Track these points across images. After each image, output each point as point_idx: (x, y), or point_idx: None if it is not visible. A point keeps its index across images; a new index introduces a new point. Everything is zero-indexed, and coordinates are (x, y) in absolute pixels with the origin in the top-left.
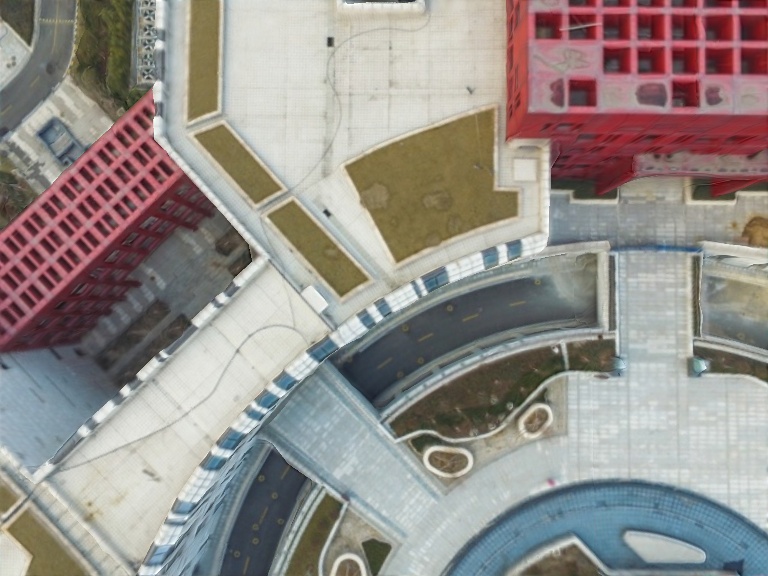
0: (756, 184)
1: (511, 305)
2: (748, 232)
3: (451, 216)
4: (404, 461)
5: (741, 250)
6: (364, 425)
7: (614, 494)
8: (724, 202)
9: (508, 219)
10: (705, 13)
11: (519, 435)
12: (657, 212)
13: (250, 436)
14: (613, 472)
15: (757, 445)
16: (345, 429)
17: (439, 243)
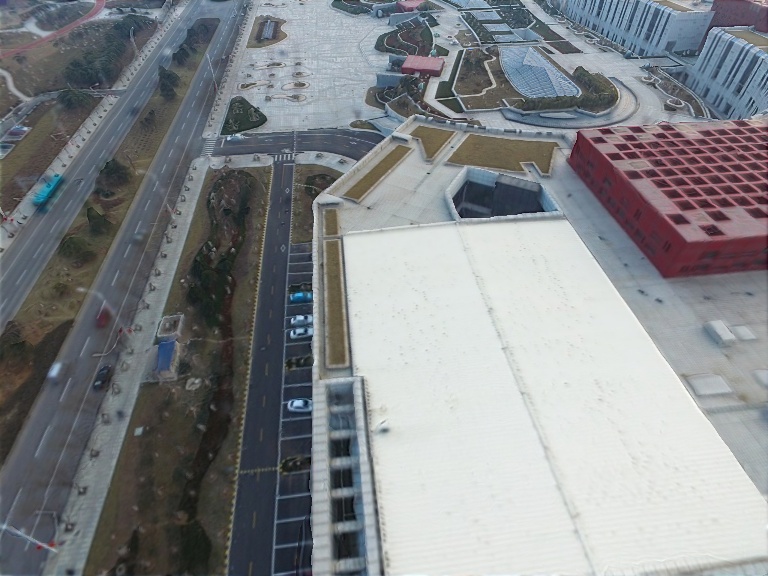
0: None
1: None
2: None
3: None
4: None
5: None
6: None
7: (586, 125)
8: None
9: None
10: (759, 143)
11: None
12: None
13: None
14: None
15: None
16: None
17: None
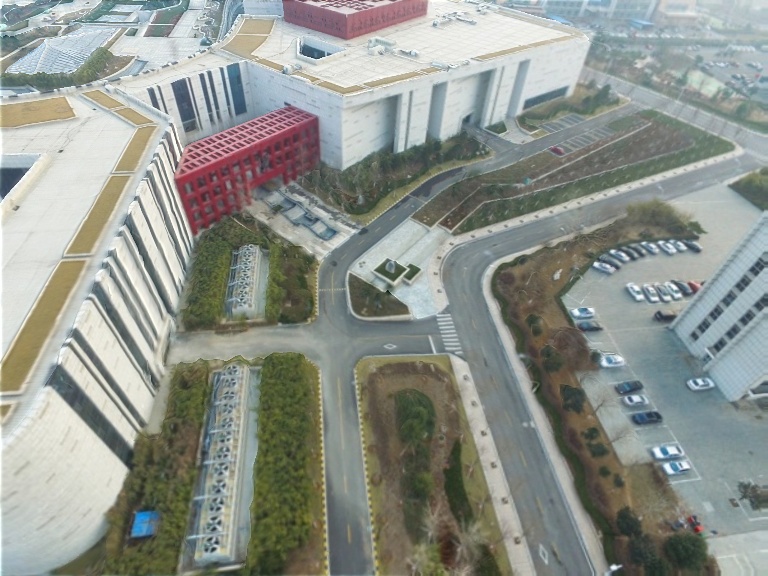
0: None
1: None
2: None
3: None
4: None
5: None
6: None
7: None
8: None
9: None
10: None
11: None
12: None
13: None
14: None
15: None
16: None
17: None
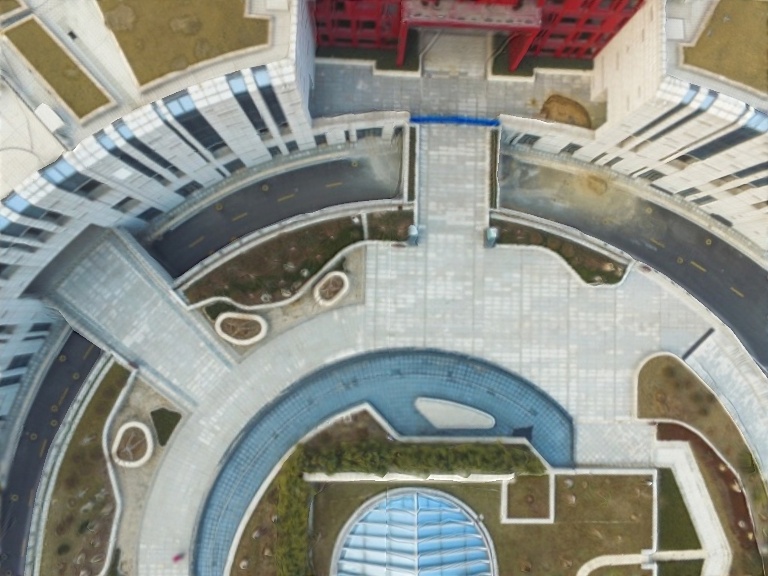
0: (551, 60)
1: (327, 186)
2: (545, 109)
3: (199, 40)
4: (197, 329)
5: (536, 124)
6: (157, 292)
7: (409, 362)
8: (523, 79)
9: (258, 46)
10: None
11: (315, 303)
12: (459, 87)
13: (18, 290)
14: (408, 341)
15: (549, 315)
16: (137, 296)
17: (186, 67)
